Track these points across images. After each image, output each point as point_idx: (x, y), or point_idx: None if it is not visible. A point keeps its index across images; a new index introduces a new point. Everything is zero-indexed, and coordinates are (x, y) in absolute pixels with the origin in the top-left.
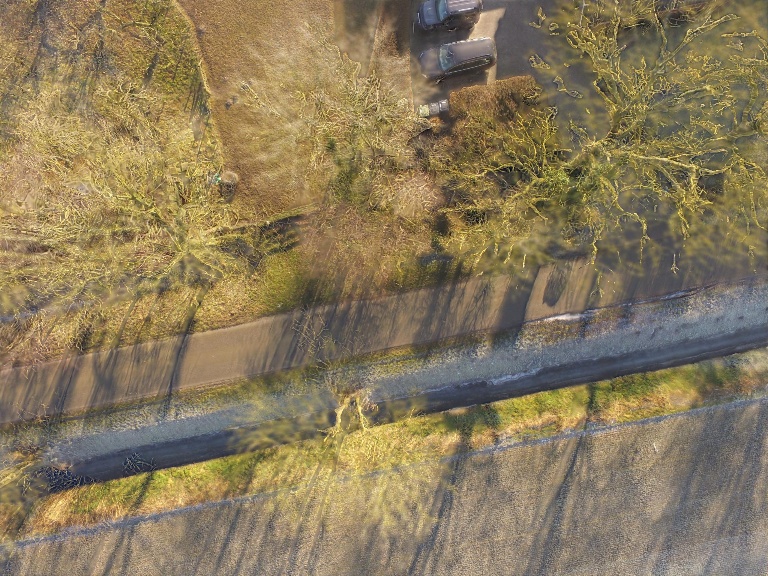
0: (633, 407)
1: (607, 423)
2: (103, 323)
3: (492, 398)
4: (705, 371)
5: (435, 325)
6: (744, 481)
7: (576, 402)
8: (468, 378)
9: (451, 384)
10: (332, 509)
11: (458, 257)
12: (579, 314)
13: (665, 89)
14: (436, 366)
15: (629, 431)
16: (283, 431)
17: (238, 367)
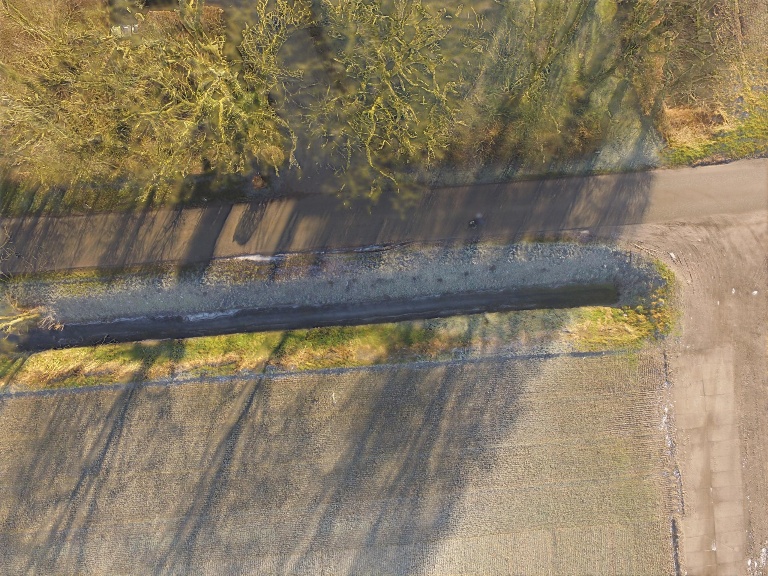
0: (316, 356)
1: (286, 368)
2: None
3: (187, 334)
4: (401, 330)
5: (122, 250)
6: (421, 443)
7: (264, 346)
8: (159, 310)
9: (144, 314)
10: (0, 422)
11: None
12: (270, 256)
13: (296, 20)
14: (120, 292)
15: (309, 379)
16: None
17: None
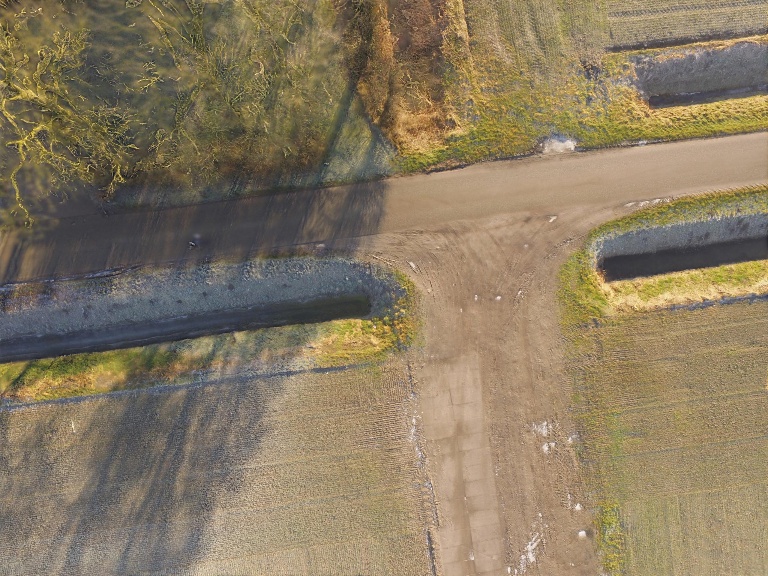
0: (53, 386)
1: (22, 400)
2: None
3: None
4: (145, 354)
5: None
6: (166, 468)
7: (4, 378)
8: None
9: None
10: None
11: None
12: None
13: None
14: None
15: (47, 410)
16: None
17: None
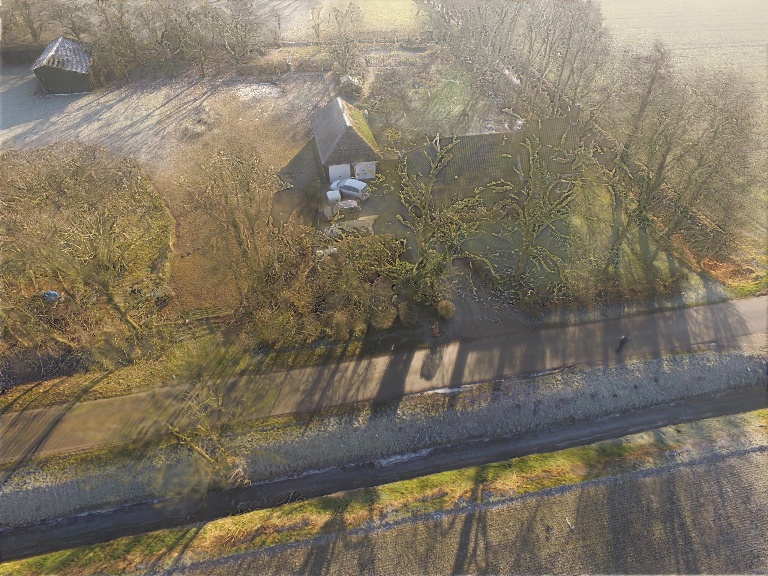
0: (531, 477)
1: (505, 493)
2: (2, 396)
3: (381, 481)
4: (602, 447)
5: (319, 396)
6: (696, 571)
7: (470, 477)
8: (353, 454)
9: (335, 462)
10: None
11: (343, 344)
12: (457, 388)
13: None
14: (317, 434)
15: (534, 504)
16: (137, 519)
17: (114, 432)
